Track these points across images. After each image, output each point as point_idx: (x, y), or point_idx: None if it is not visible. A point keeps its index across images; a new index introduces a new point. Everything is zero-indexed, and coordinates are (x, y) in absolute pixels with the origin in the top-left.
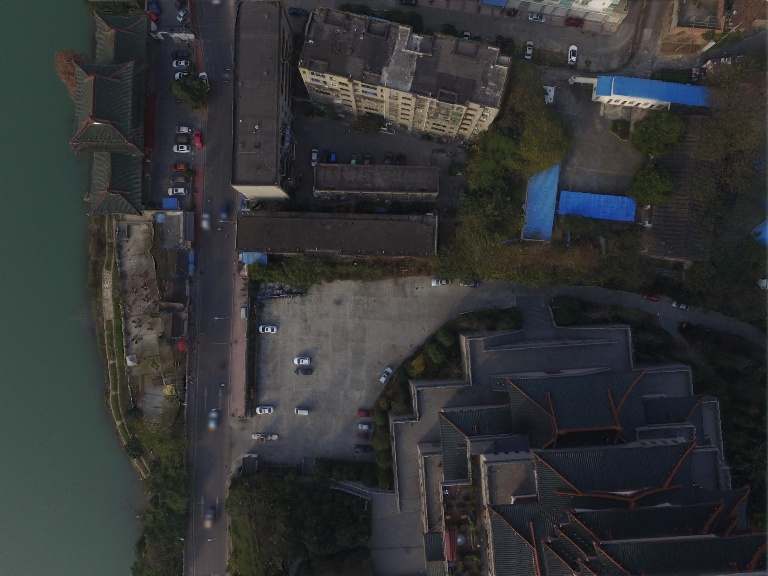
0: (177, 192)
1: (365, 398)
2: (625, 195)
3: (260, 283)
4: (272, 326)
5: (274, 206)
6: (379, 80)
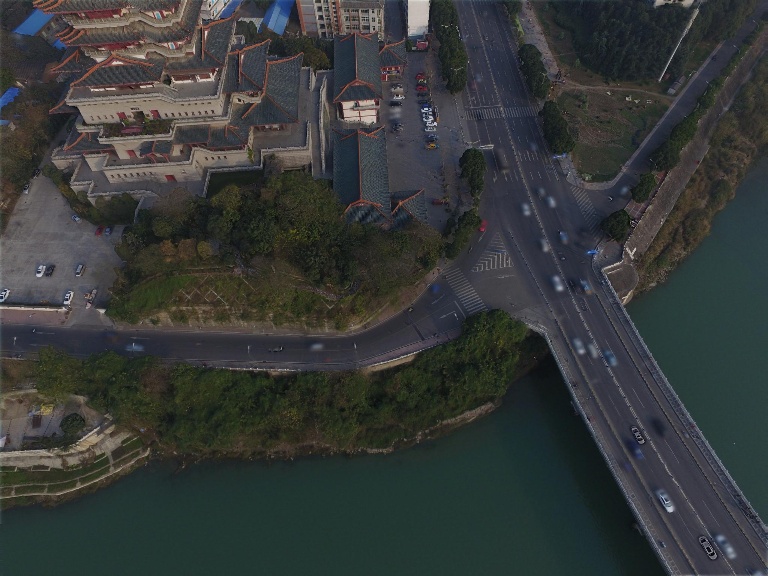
0: None
1: (90, 232)
2: (5, 92)
3: None
4: None
5: None
6: None
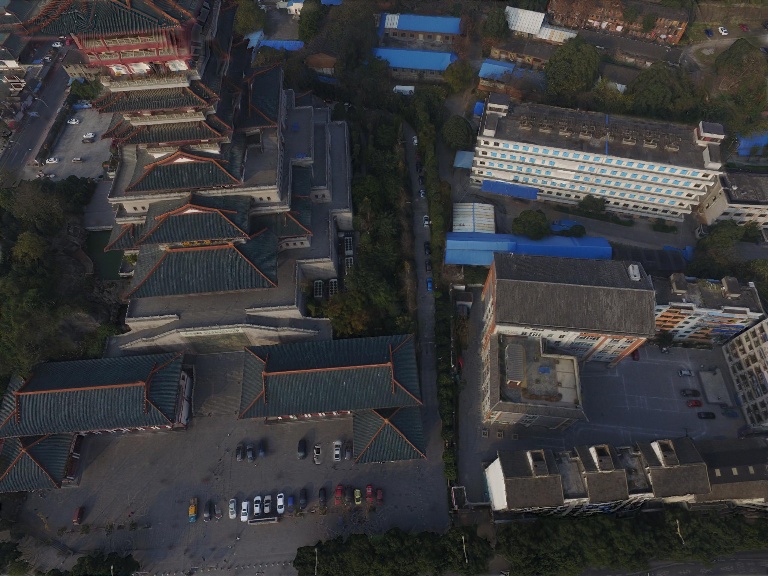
0: (45, 59)
1: None
2: (298, 40)
3: (78, 100)
4: None
5: None
6: None
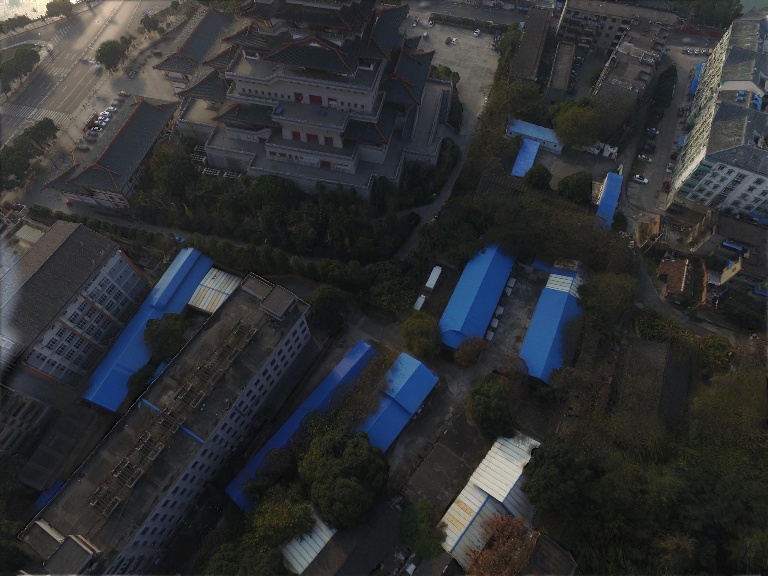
0: None
1: None
2: None
3: None
4: (478, 34)
5: (551, 35)
6: (625, 40)
